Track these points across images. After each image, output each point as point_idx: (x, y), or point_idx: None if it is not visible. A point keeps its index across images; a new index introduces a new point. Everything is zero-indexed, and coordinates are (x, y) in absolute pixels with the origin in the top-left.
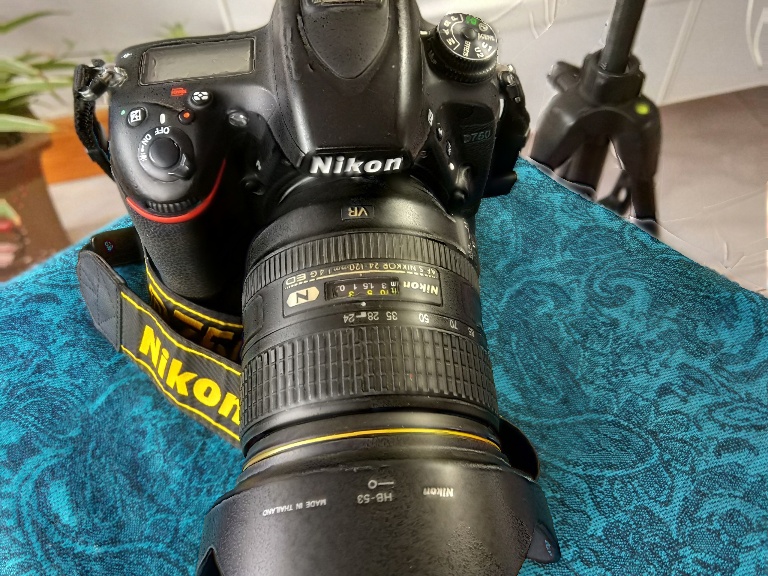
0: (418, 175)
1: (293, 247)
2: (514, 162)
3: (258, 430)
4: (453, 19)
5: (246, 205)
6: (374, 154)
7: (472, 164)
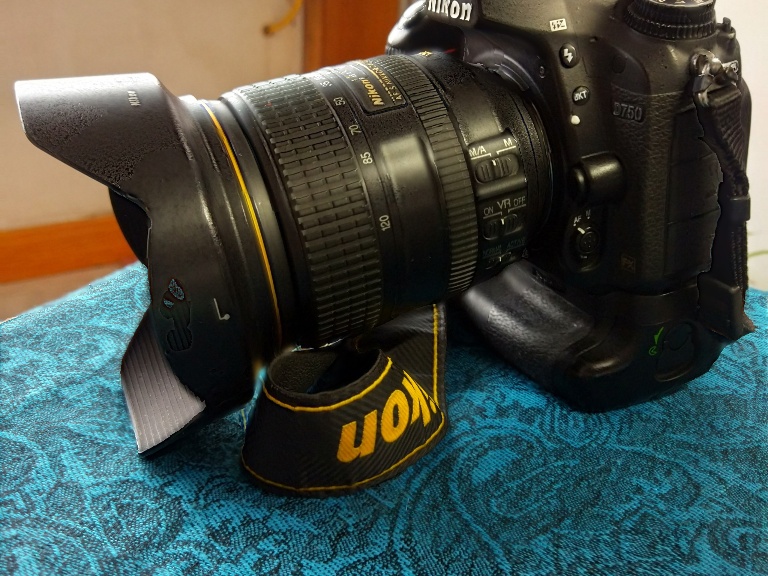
0: (541, 110)
1: None
2: (729, 255)
3: None
4: None
5: None
6: None
7: (624, 162)
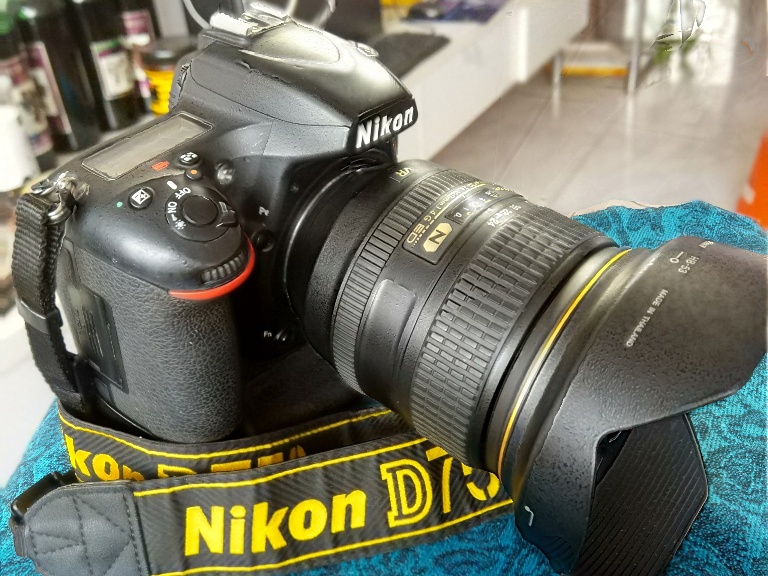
0: None
1: (382, 221)
2: None
3: (505, 358)
4: None
5: (255, 275)
6: (398, 107)
7: None
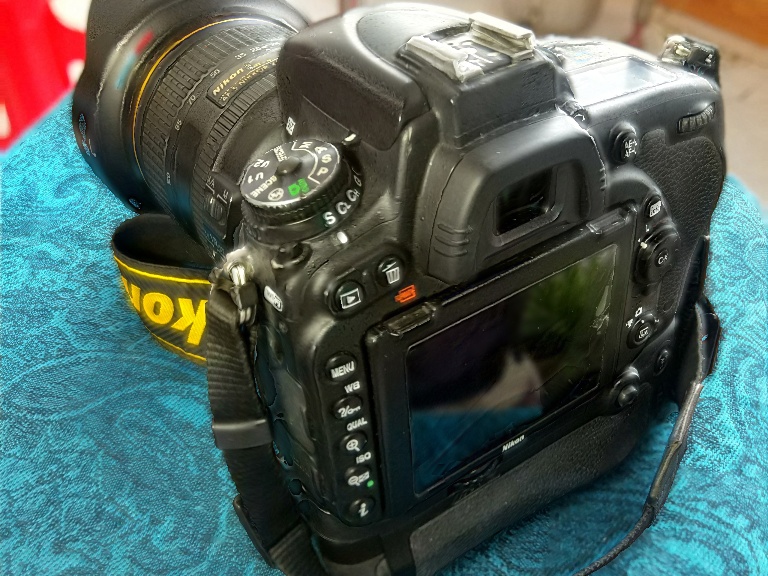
0: None
1: None
2: None
3: None
4: (323, 169)
5: None
6: None
7: None
